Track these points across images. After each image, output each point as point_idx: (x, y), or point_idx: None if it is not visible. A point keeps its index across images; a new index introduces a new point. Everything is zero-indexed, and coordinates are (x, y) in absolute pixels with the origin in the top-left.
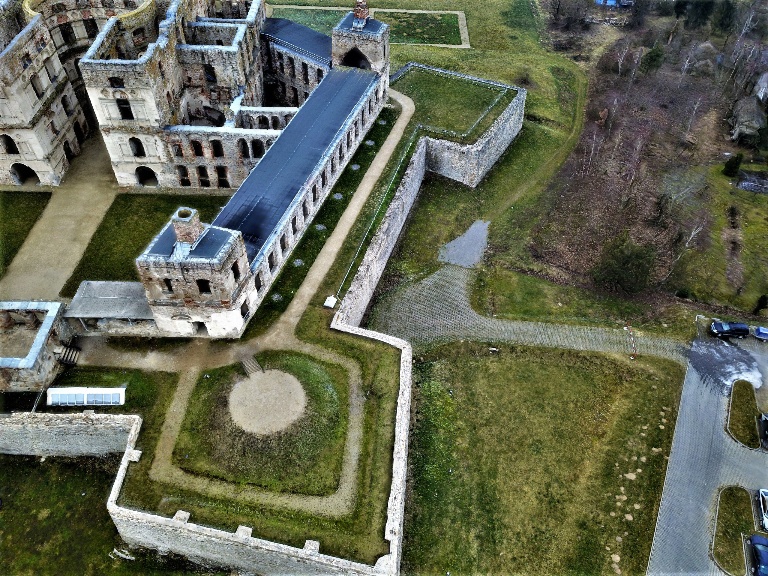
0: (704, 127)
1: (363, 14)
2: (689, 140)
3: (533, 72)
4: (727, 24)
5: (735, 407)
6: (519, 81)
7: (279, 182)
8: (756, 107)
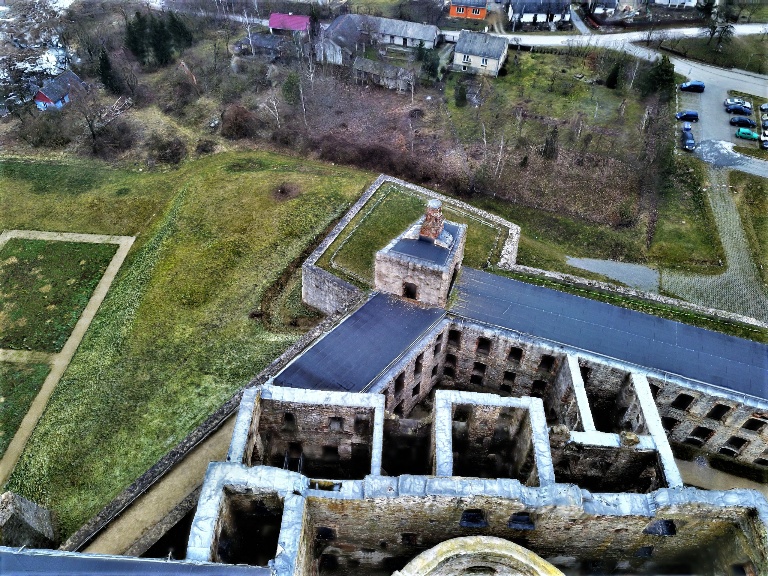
0: (485, 79)
1: (443, 224)
2: (404, 112)
3: (254, 183)
4: (190, 39)
5: (761, 157)
6: (281, 196)
7: (765, 364)
8: (378, 62)
